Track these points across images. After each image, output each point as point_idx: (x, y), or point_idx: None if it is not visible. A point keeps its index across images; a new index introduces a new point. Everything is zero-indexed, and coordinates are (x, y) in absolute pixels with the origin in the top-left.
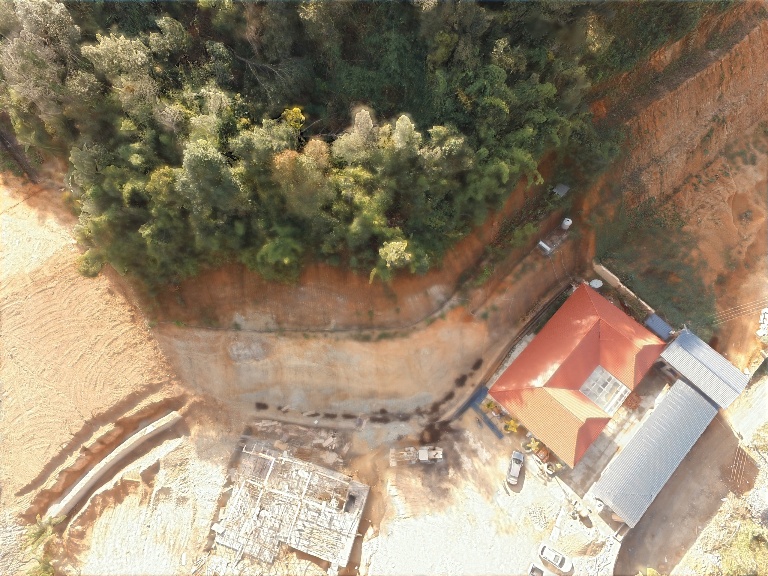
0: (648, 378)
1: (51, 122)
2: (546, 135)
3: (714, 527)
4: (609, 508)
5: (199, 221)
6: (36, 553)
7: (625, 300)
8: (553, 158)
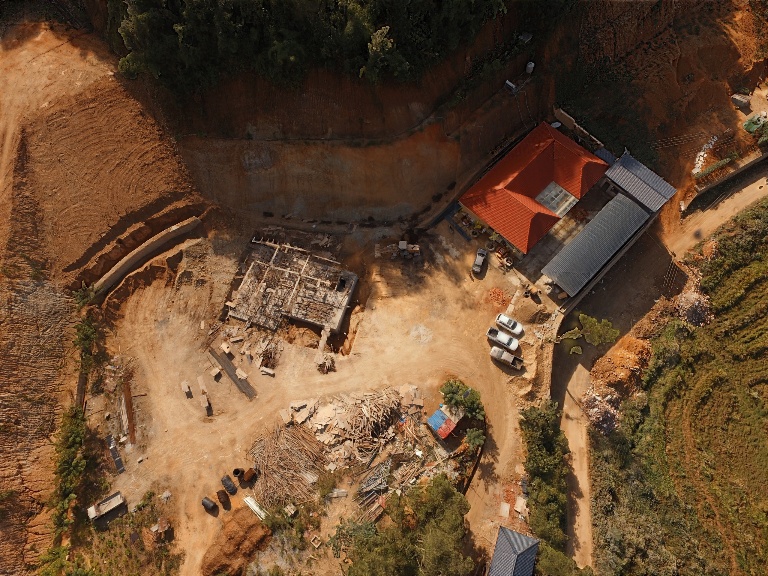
0: (595, 198)
1: None
2: None
3: (646, 320)
4: (556, 291)
5: (222, 21)
6: None
7: (579, 136)
8: (519, 7)
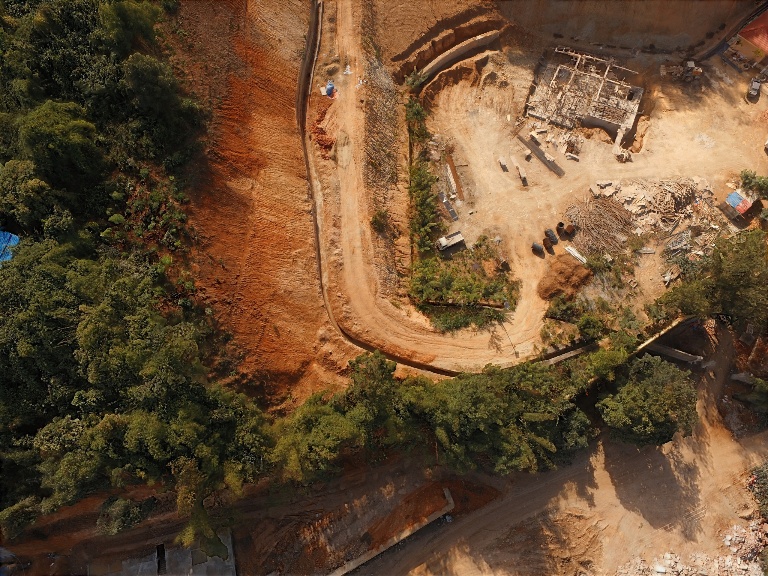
0: None
1: None
2: None
3: None
4: None
5: None
6: (403, 101)
7: None
8: None
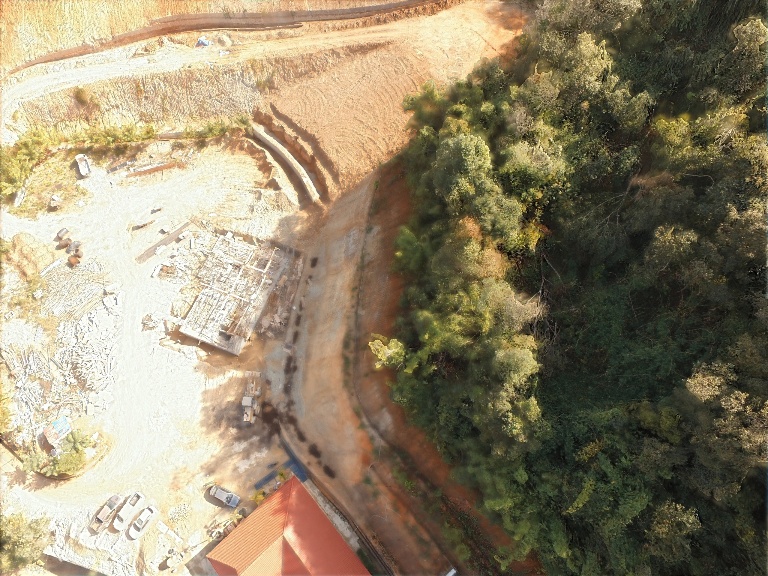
0: None
1: (528, 38)
2: None
3: None
4: None
5: (434, 172)
6: (235, 123)
7: None
8: None
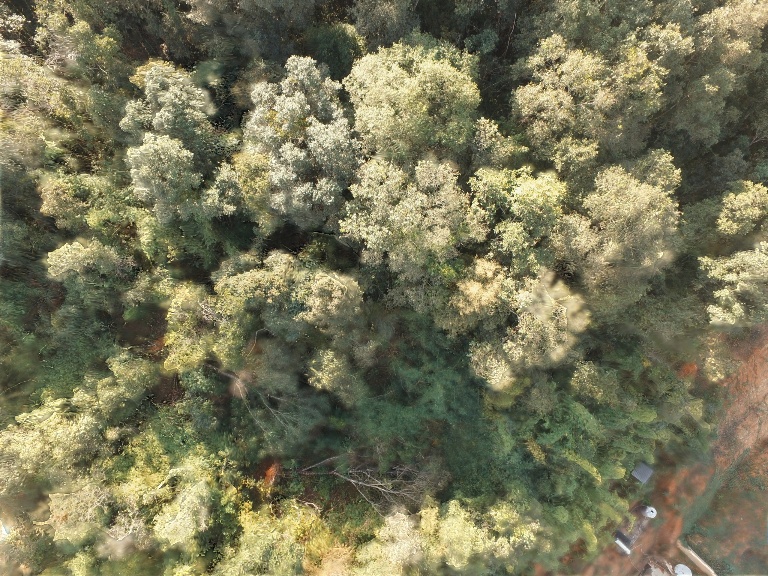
0: None
1: None
2: (637, 454)
3: None
4: None
5: None
6: None
7: None
8: None
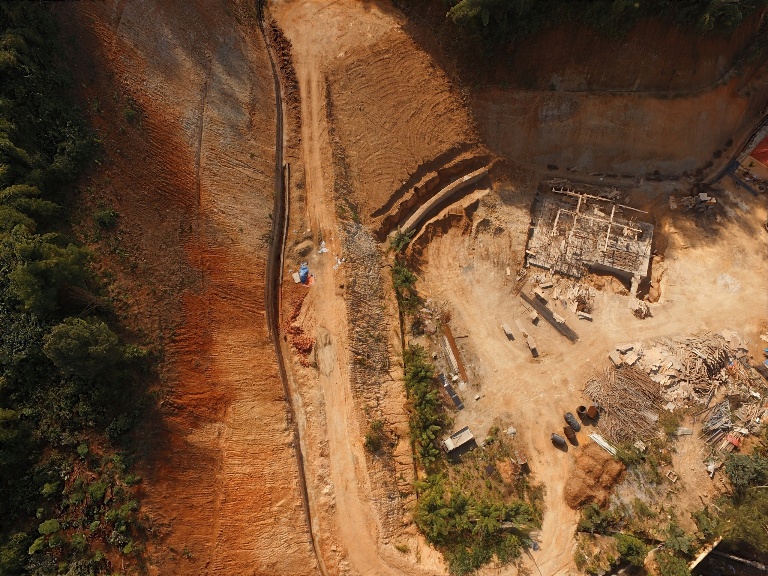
0: None
1: None
2: None
3: None
4: None
5: None
6: (388, 262)
7: None
8: None
